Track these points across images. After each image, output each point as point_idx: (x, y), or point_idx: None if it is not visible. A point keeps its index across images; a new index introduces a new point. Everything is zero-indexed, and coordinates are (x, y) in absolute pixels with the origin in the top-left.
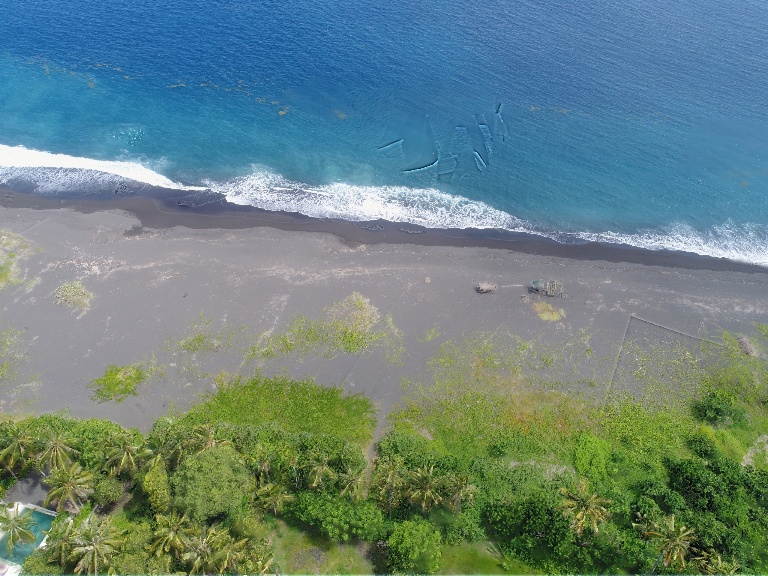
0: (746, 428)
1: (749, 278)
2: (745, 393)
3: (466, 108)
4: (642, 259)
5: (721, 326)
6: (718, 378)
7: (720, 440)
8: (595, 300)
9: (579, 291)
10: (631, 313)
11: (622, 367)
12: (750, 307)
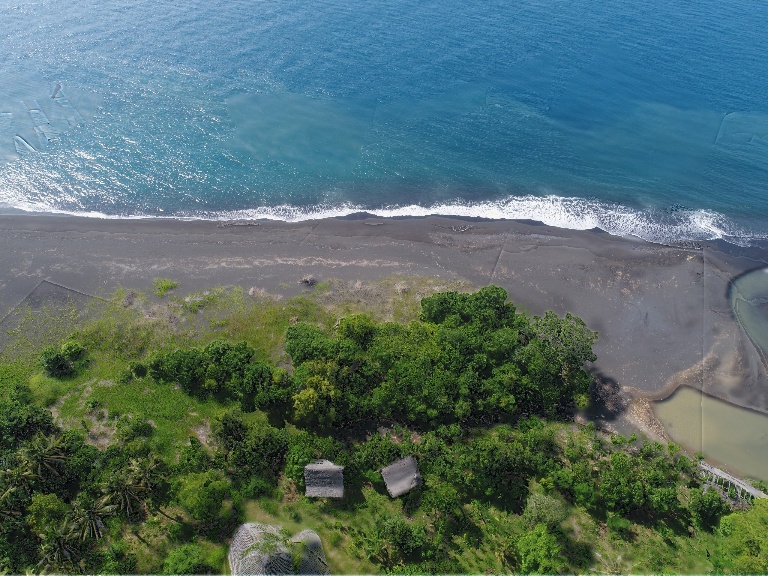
0: (81, 374)
1: (199, 239)
2: (102, 342)
3: (14, 94)
4: (114, 228)
5: (121, 283)
6: (84, 331)
7: (39, 386)
8: (21, 268)
9: (12, 260)
10: (46, 277)
11: (0, 327)
12: (169, 265)
